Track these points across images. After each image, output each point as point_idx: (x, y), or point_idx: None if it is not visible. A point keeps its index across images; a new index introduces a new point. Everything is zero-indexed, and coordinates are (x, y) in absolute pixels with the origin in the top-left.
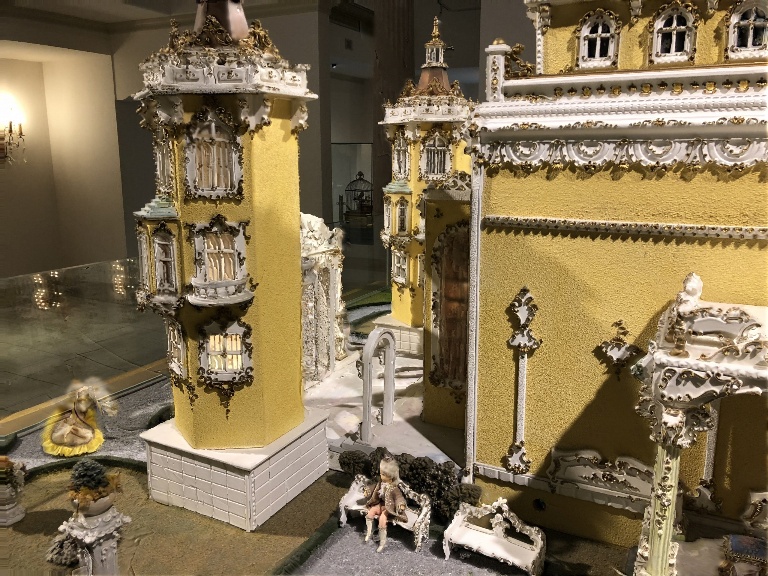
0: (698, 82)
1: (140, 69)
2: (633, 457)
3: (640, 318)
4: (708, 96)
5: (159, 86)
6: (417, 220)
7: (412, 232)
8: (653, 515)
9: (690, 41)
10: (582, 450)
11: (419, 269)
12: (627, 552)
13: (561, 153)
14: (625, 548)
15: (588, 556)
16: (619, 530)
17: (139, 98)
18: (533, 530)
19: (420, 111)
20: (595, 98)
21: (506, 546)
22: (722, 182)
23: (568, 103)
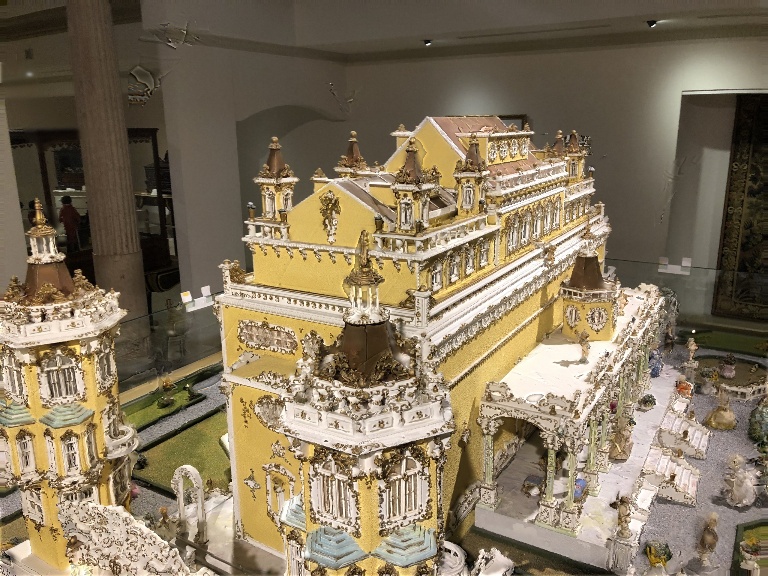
0: (474, 292)
1: (360, 416)
2: (469, 485)
3: (468, 414)
4: (481, 298)
5: (436, 421)
6: (103, 439)
7: (101, 455)
8: (572, 484)
9: (458, 269)
10: (458, 500)
11: (112, 490)
12: (469, 534)
13: (452, 346)
14: (466, 533)
15: (475, 549)
16: (464, 527)
17: (386, 447)
18: (493, 551)
19: (95, 319)
20: (452, 310)
21: (491, 571)
22: (482, 335)
23: (452, 317)
